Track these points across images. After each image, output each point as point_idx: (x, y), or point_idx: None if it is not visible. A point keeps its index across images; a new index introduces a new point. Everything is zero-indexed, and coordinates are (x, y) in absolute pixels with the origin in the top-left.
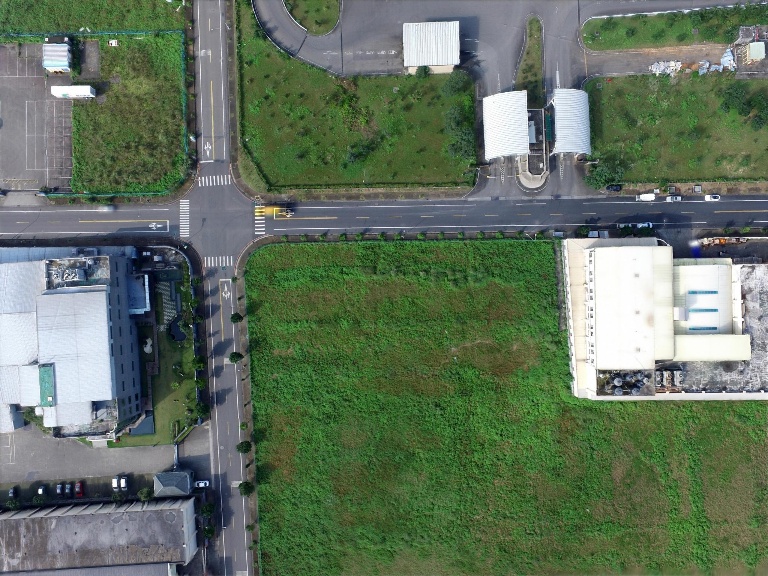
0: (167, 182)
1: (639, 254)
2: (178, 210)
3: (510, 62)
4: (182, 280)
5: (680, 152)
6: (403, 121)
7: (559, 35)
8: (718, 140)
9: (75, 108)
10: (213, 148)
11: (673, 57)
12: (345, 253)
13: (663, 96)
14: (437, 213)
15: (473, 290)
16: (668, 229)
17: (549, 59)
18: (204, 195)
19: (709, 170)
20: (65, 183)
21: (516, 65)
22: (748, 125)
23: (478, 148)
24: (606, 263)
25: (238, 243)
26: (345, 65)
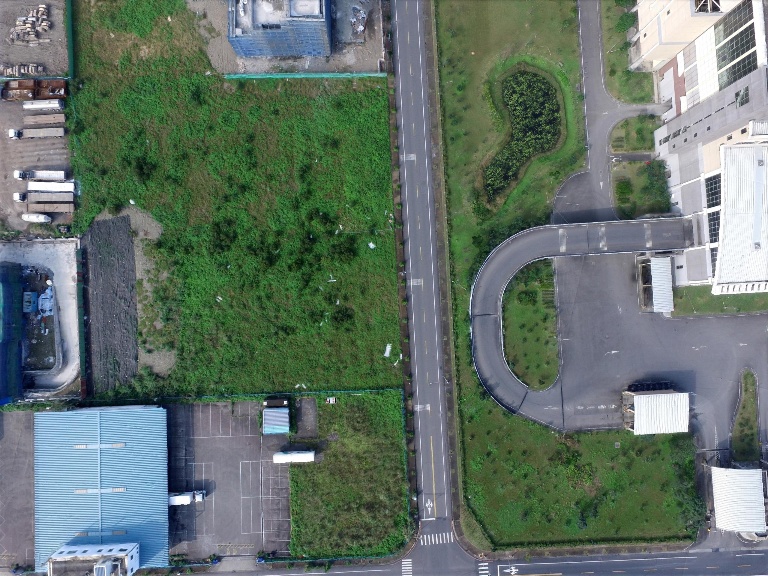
0: (390, 544)
1: None
2: (400, 570)
3: (726, 415)
4: None
5: None
6: (625, 476)
7: None
8: None
9: (293, 469)
10: (435, 505)
11: None
12: None
13: None
14: (660, 566)
15: None
16: None
17: (763, 411)
18: (427, 554)
19: None
20: (283, 546)
21: (732, 418)
22: None
23: None
24: None
25: None
26: (566, 420)
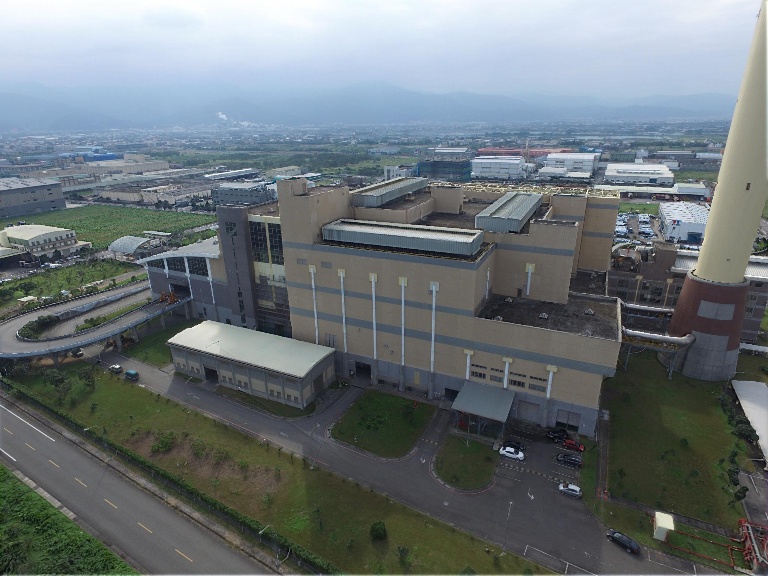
0: None
1: None
2: None
3: None
4: None
5: None
6: None
7: None
8: None
9: None
10: None
11: None
12: None
13: None
14: None
15: None
16: (28, 270)
17: None
18: None
19: None
20: None
21: None
22: None
23: None
24: None
25: None
26: None
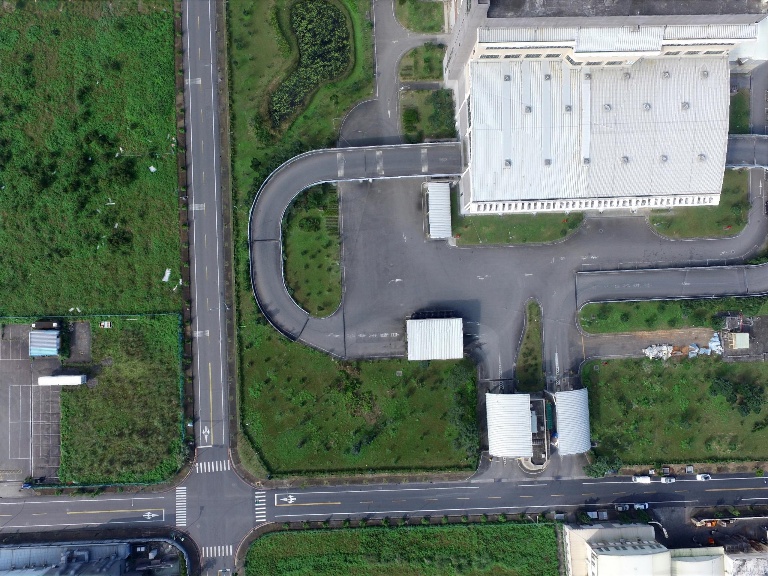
0: (163, 471)
1: (640, 563)
2: (174, 498)
3: (511, 345)
4: (179, 574)
5: (673, 433)
6: (406, 405)
7: (557, 318)
8: (708, 421)
9: (64, 394)
10: (211, 433)
11: (665, 340)
12: (349, 540)
13: (656, 379)
14: (441, 496)
15: (477, 575)
16: (663, 508)
17: (548, 342)
18: (202, 482)
19: (700, 450)
20: (52, 473)
21: (517, 348)
22: (735, 408)
23: (481, 431)
24: (608, 571)
25: (238, 531)
26: (348, 348)
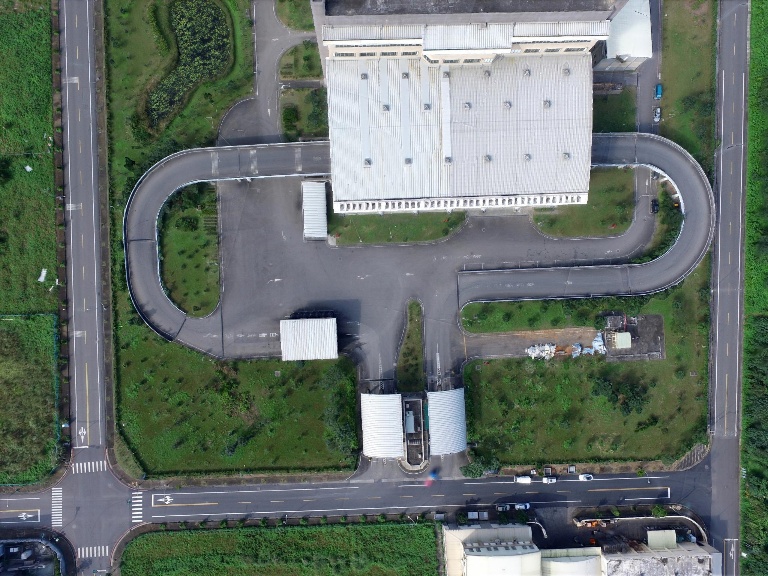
0: (38, 471)
1: (508, 564)
2: (50, 499)
3: (391, 345)
4: (53, 575)
5: (555, 433)
6: (285, 405)
7: (439, 318)
8: (591, 421)
9: None
10: (88, 433)
11: (548, 340)
12: (226, 540)
13: (538, 379)
14: (320, 497)
15: (356, 575)
16: (545, 508)
17: (429, 342)
18: (78, 483)
19: (583, 450)
20: None
21: (397, 348)
22: (618, 408)
23: (360, 431)
24: (477, 571)
25: (114, 532)
26: (226, 348)
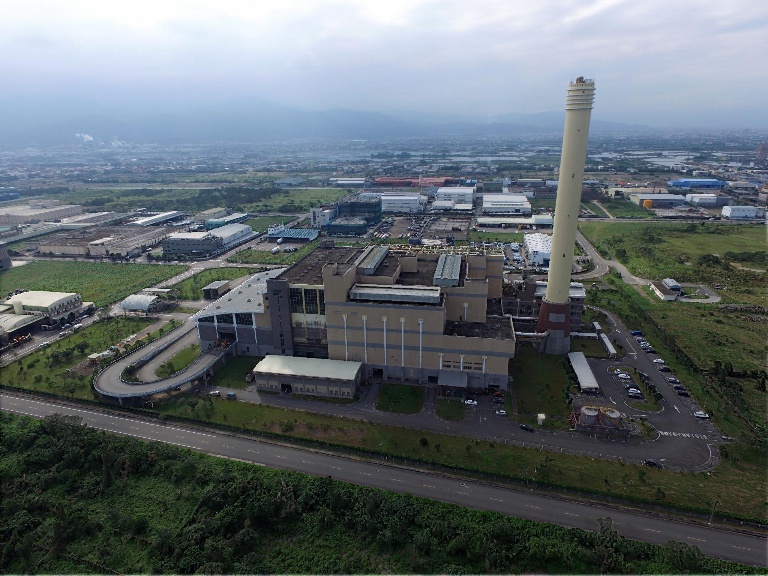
0: None
1: None
2: None
3: None
4: None
5: None
6: None
7: None
8: None
9: None
10: None
11: None
12: None
13: None
14: None
15: None
16: None
17: None
18: None
19: None
20: None
21: None
22: None
23: None
24: None
25: None
26: None
